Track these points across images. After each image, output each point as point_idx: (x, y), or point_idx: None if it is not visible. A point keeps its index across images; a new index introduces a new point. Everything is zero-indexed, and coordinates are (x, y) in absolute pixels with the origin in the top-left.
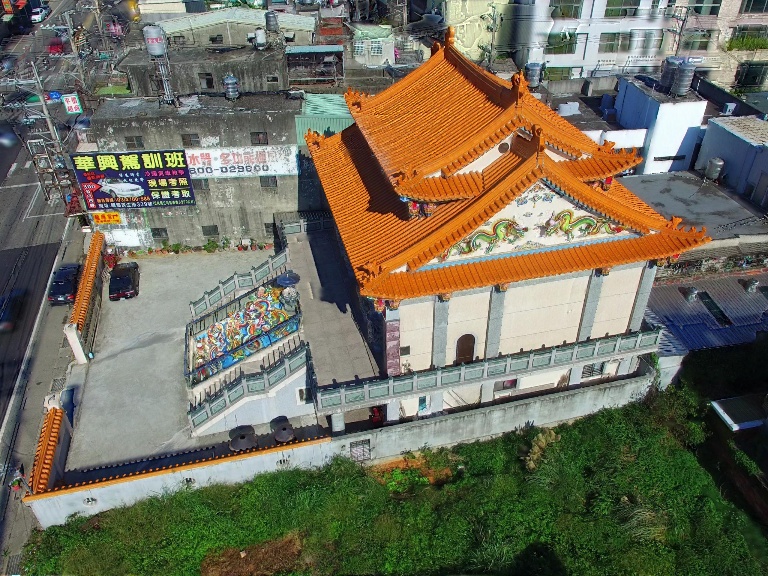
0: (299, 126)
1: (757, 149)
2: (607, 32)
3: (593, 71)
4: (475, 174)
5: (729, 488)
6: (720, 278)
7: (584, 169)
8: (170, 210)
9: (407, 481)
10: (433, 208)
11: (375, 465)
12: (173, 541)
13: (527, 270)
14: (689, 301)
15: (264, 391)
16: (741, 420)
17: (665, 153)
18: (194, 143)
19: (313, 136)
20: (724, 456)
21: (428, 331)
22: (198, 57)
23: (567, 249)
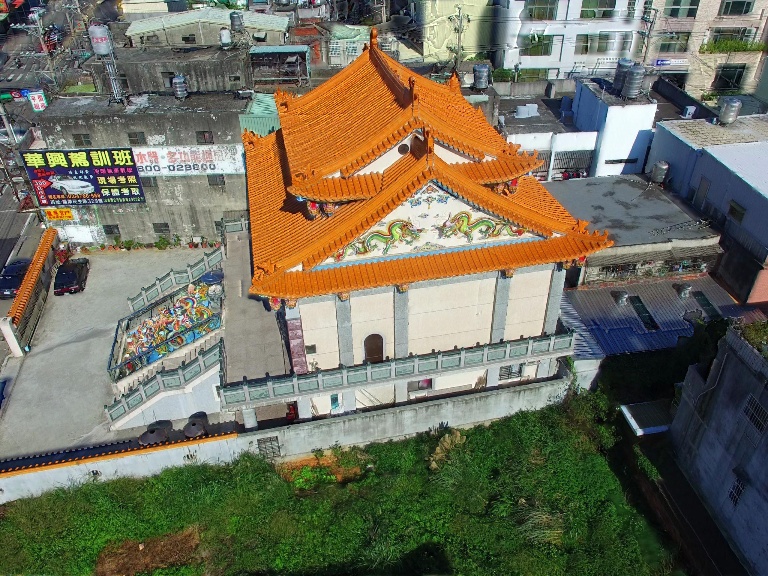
0: (243, 125)
1: (697, 153)
2: (583, 34)
3: (570, 73)
4: (375, 175)
5: (634, 493)
6: (655, 282)
7: (487, 171)
8: (121, 207)
9: (315, 479)
10: (333, 208)
11: (286, 462)
12: (73, 532)
13: (424, 271)
14: (619, 305)
15: (180, 387)
16: (647, 425)
17: (616, 156)
18: (141, 141)
19: (249, 136)
20: (633, 461)
21: (333, 330)
22: (162, 56)
23: (468, 251)
